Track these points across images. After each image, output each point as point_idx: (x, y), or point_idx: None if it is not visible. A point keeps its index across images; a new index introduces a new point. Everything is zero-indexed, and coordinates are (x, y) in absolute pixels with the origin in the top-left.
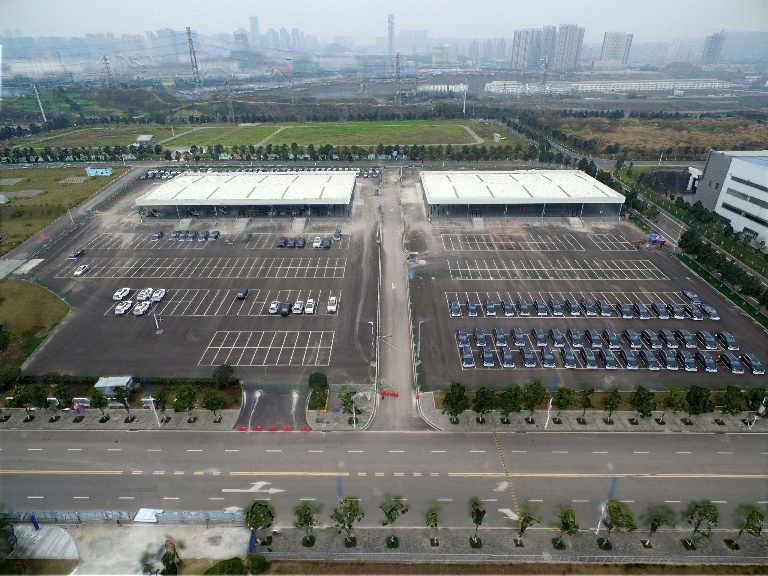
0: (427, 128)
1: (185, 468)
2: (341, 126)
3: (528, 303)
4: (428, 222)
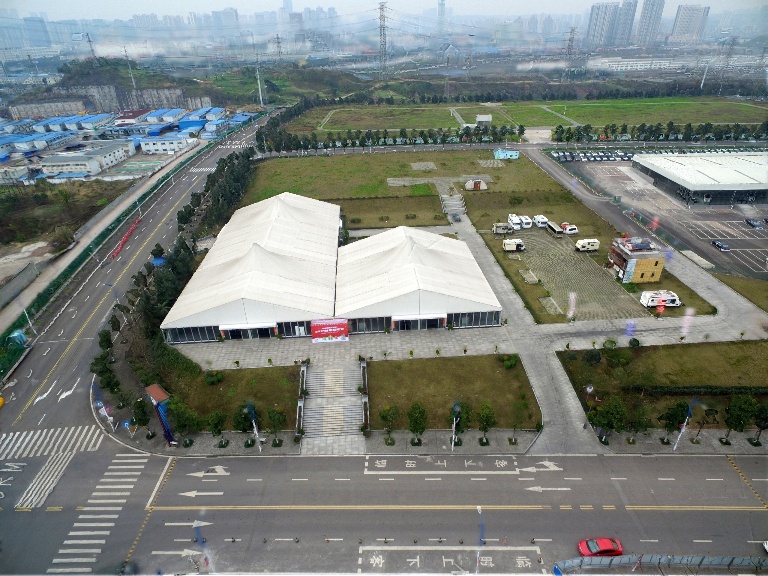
0: (706, 105)
1: None
2: (603, 104)
3: None
4: None
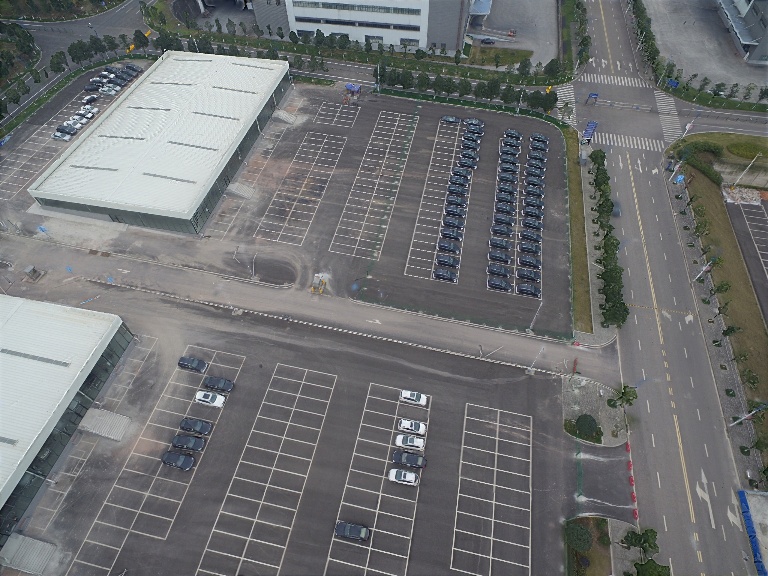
0: None
1: (697, 573)
2: None
3: (441, 217)
4: (205, 239)
